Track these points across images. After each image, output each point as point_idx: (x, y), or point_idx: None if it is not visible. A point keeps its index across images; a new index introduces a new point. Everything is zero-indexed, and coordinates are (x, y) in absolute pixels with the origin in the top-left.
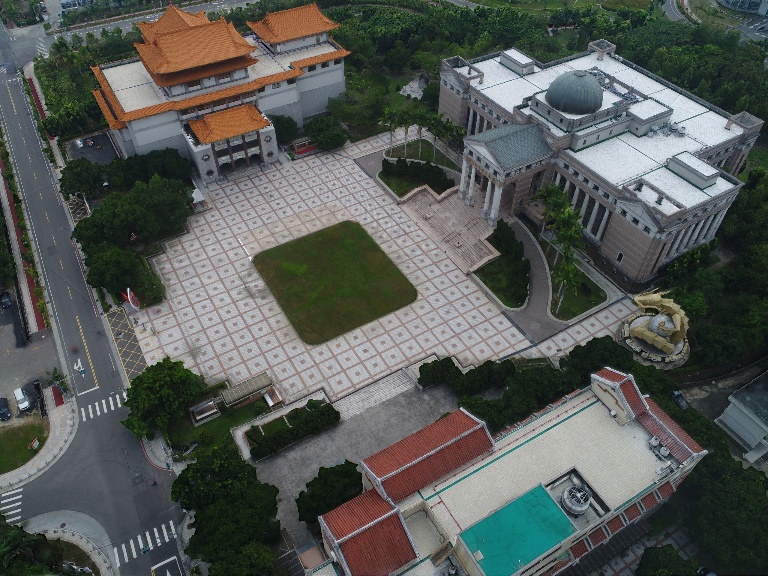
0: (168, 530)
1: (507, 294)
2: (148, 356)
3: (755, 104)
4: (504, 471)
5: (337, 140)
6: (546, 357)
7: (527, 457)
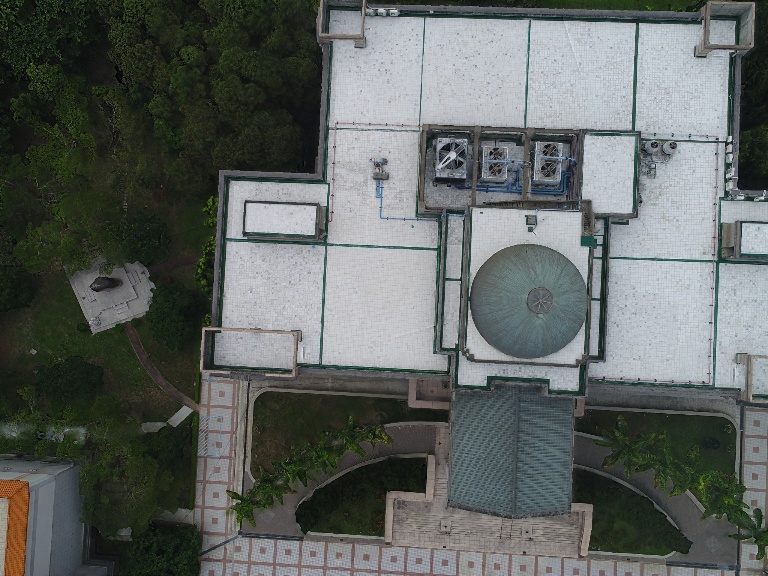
0: None
1: (650, 541)
2: None
3: None
4: None
5: (197, 559)
6: (766, 575)
7: None
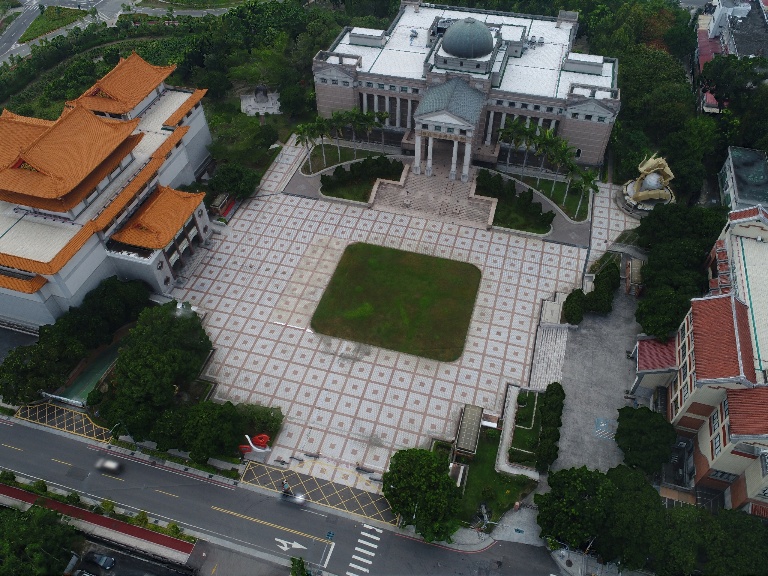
0: None
1: (532, 225)
2: (339, 479)
3: (519, 9)
4: (766, 316)
5: (256, 182)
6: (607, 251)
7: (762, 299)
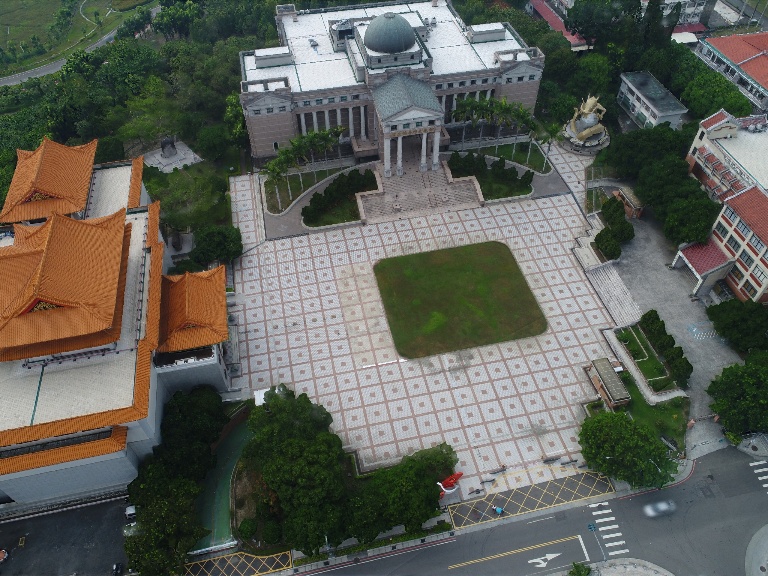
0: (760, 467)
1: (516, 189)
2: (537, 479)
3: None
4: None
5: None
6: (587, 190)
7: (767, 181)
